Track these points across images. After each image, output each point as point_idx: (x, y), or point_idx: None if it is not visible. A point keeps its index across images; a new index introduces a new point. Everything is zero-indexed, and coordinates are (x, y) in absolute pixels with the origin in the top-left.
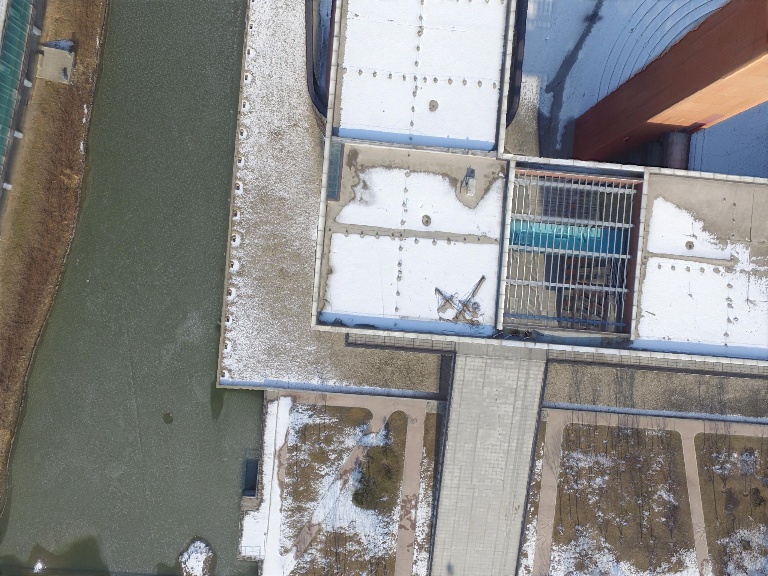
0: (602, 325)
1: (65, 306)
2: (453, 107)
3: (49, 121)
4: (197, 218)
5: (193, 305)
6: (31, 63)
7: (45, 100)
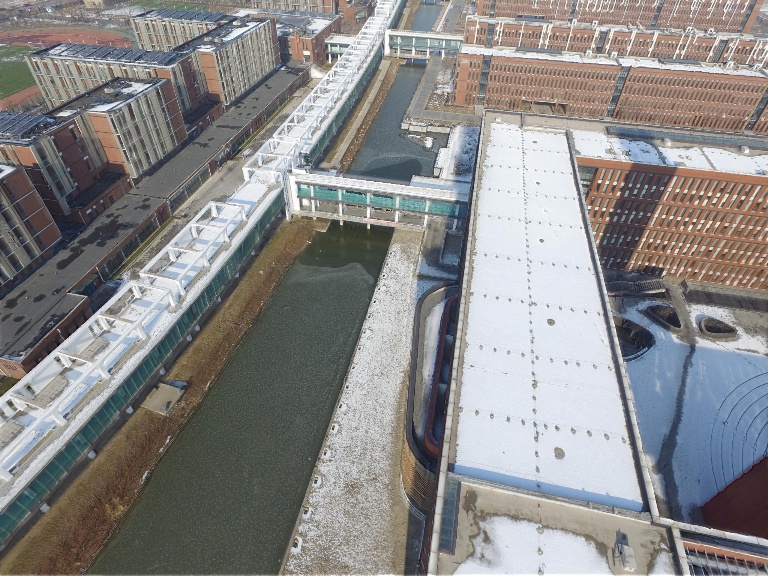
0: None
1: None
2: (582, 457)
3: (128, 446)
4: None
5: None
6: (143, 394)
7: (136, 426)
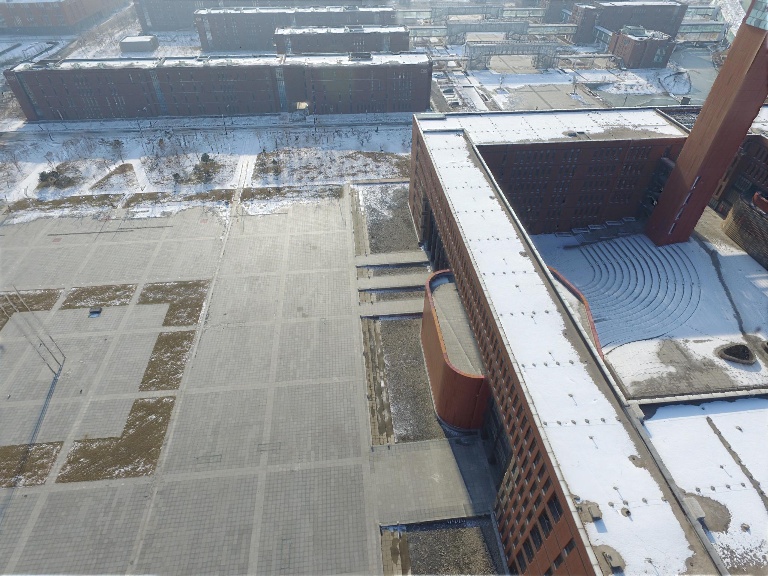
0: (668, 113)
1: None
2: None
3: None
4: None
5: None
6: None
7: None
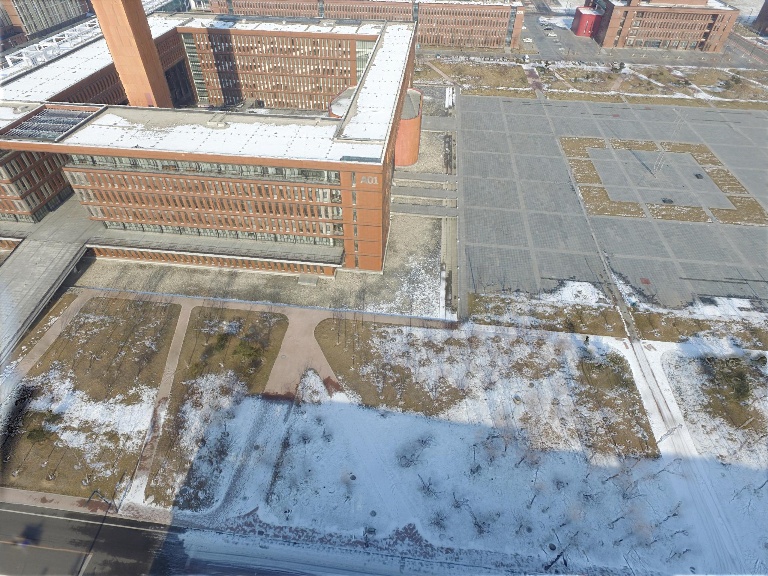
0: None
1: None
2: None
3: None
4: None
5: None
6: None
7: None
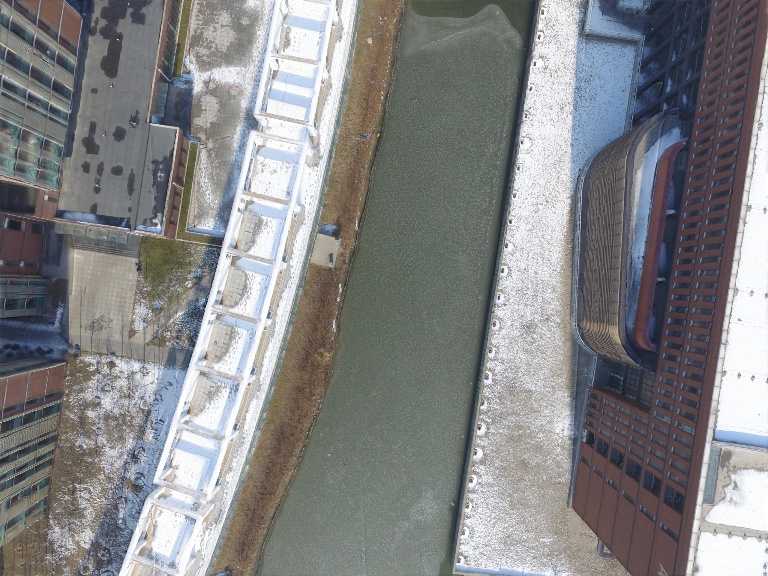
0: None
1: (306, 478)
2: None
3: (310, 302)
4: (439, 400)
5: (429, 485)
6: None
7: (308, 282)
